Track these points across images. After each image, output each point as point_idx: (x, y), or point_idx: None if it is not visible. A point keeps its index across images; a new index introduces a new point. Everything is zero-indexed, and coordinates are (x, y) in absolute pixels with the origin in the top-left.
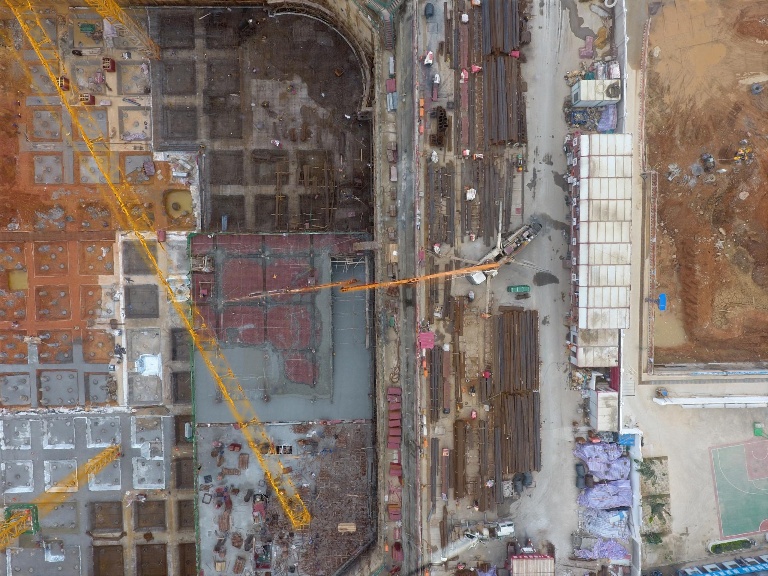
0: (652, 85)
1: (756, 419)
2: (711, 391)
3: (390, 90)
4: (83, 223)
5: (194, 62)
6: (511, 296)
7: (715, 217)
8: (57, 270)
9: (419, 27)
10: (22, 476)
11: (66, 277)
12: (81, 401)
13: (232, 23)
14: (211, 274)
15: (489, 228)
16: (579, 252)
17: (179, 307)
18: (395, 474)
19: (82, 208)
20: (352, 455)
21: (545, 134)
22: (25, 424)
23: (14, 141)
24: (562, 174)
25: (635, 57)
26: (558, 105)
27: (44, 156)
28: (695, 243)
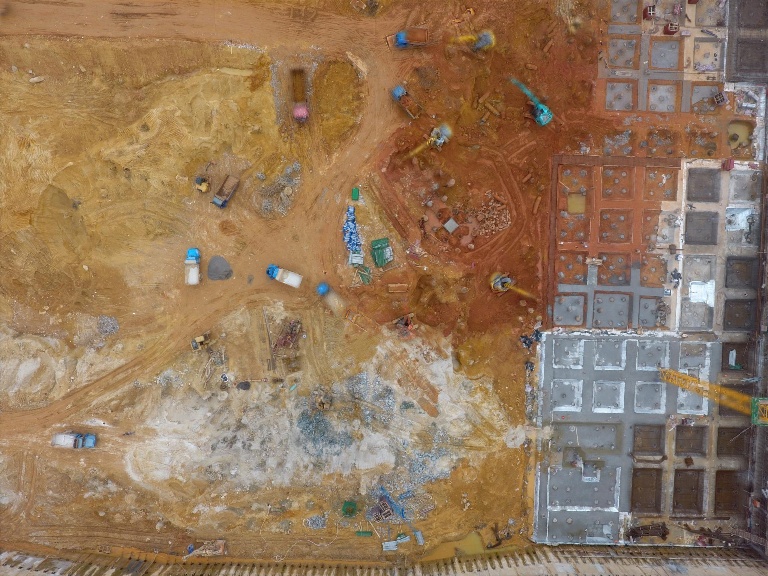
0: None
1: None
2: None
3: None
4: (655, 149)
5: None
6: None
7: None
8: (618, 195)
9: None
10: (568, 395)
11: (631, 201)
12: (635, 324)
13: None
14: None
15: None
16: None
17: (732, 236)
18: None
19: (648, 135)
20: None
21: None
22: (575, 344)
23: (594, 67)
24: None
25: None
26: None
27: (616, 83)
28: None
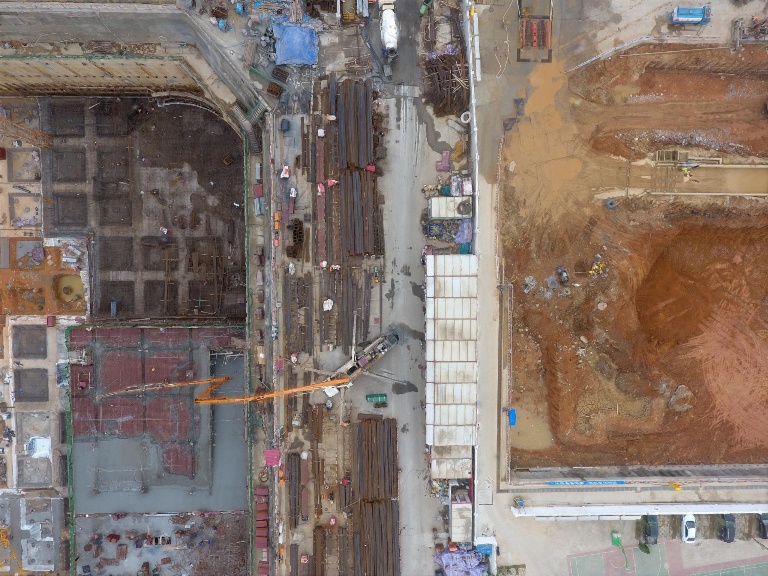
0: (508, 199)
1: (614, 528)
2: (569, 500)
3: (257, 195)
4: None
5: (84, 150)
6: (370, 404)
7: (578, 324)
8: None
9: (276, 141)
10: None
11: None
12: None
13: (121, 112)
14: (90, 366)
15: (347, 337)
16: (426, 370)
17: None
18: (263, 573)
19: None
20: (226, 549)
21: (403, 246)
22: None
23: None
24: (420, 285)
25: (491, 172)
26: (416, 217)
27: None
28: (556, 351)
